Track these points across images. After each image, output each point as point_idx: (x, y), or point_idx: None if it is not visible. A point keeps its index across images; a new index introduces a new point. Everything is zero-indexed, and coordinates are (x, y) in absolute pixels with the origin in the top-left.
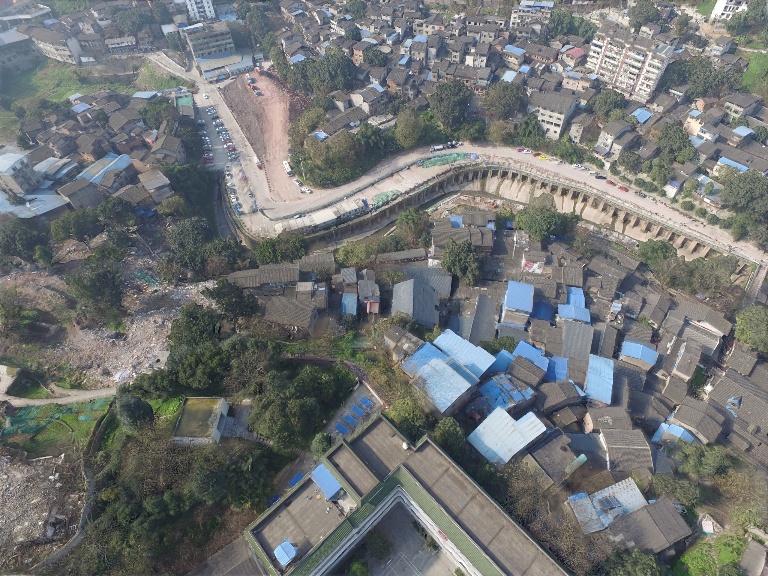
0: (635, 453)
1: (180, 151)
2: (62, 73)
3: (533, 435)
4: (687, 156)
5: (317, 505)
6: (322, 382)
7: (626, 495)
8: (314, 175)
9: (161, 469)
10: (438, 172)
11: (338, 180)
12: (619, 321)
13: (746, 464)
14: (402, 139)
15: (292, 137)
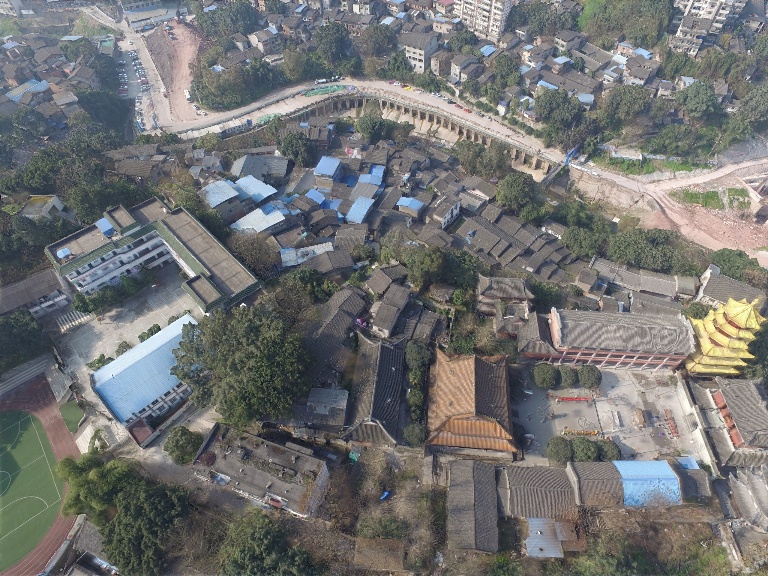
0: (353, 240)
1: (94, 80)
2: (5, 24)
3: (274, 222)
4: (513, 80)
5: (96, 238)
6: (130, 189)
7: (322, 250)
8: (208, 100)
9: (6, 235)
10: (318, 100)
11: (229, 104)
12: (407, 187)
13: None
14: (288, 72)
15: (193, 70)
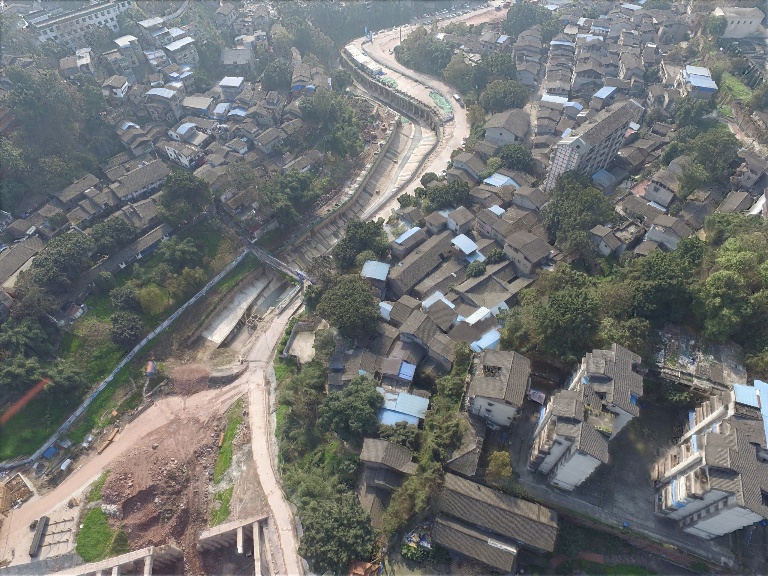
0: None
1: None
2: None
3: None
4: None
5: None
6: None
7: (85, 60)
8: None
9: None
10: (425, 101)
11: None
12: None
13: (111, 158)
14: None
15: None
